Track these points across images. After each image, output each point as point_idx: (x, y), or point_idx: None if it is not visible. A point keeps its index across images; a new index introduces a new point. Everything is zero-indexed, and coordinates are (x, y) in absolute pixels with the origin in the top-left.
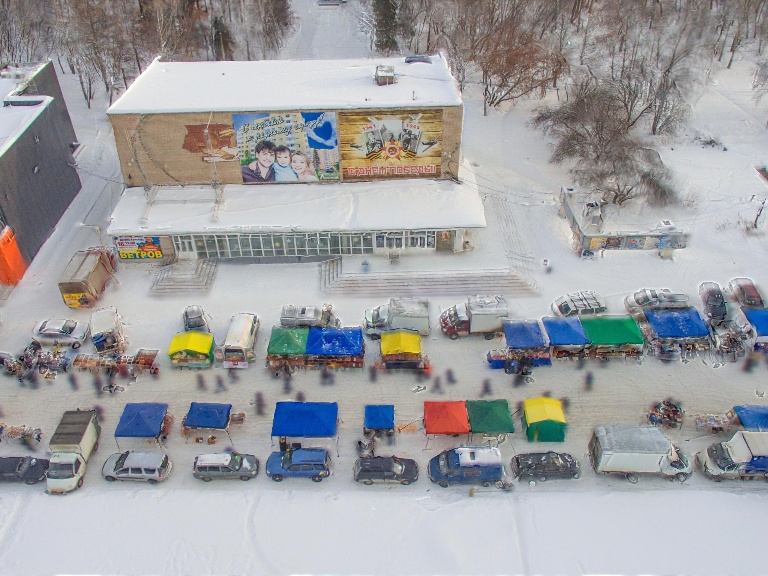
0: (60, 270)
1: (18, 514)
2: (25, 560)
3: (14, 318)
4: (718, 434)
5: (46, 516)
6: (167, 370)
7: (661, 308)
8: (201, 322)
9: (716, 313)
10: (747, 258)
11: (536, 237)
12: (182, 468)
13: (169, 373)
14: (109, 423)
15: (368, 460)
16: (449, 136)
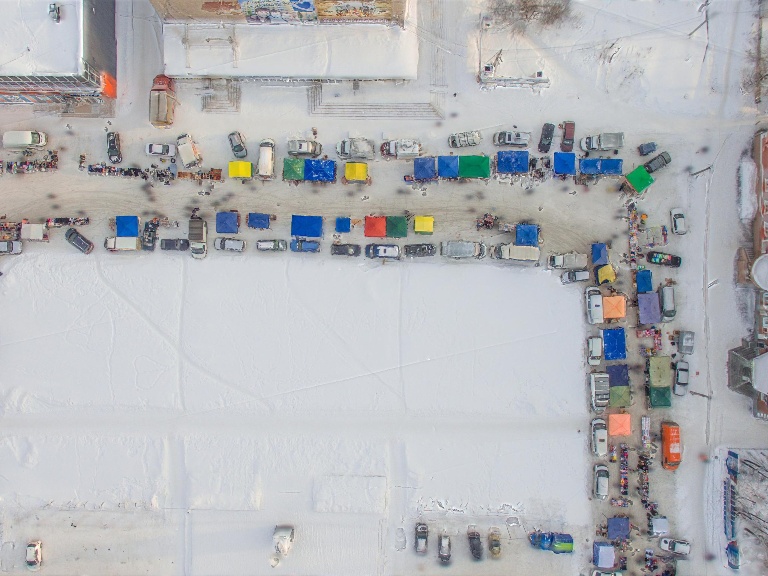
0: (137, 88)
1: (185, 267)
2: (197, 290)
3: (127, 135)
4: (508, 233)
5: (198, 269)
6: (229, 180)
7: (509, 151)
8: (241, 147)
9: (543, 149)
10: (589, 93)
11: (455, 65)
12: (251, 244)
13: (231, 183)
14: (209, 216)
15: (338, 248)
16: (397, 8)
